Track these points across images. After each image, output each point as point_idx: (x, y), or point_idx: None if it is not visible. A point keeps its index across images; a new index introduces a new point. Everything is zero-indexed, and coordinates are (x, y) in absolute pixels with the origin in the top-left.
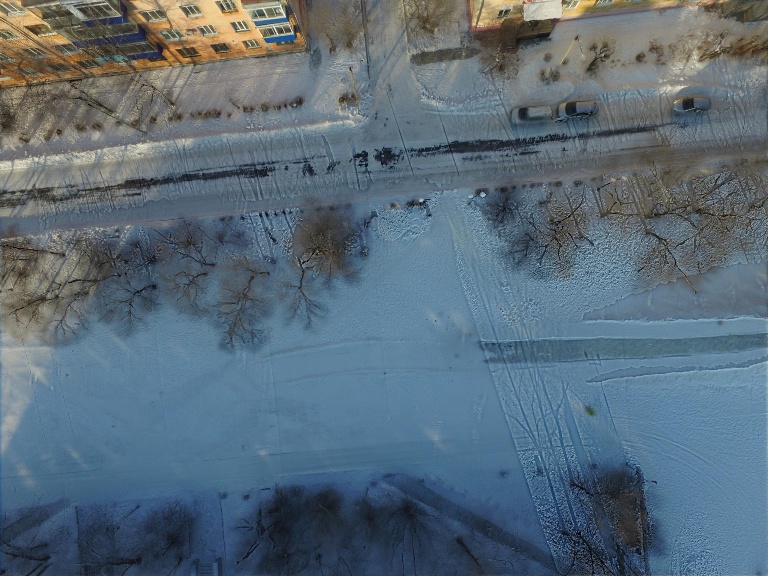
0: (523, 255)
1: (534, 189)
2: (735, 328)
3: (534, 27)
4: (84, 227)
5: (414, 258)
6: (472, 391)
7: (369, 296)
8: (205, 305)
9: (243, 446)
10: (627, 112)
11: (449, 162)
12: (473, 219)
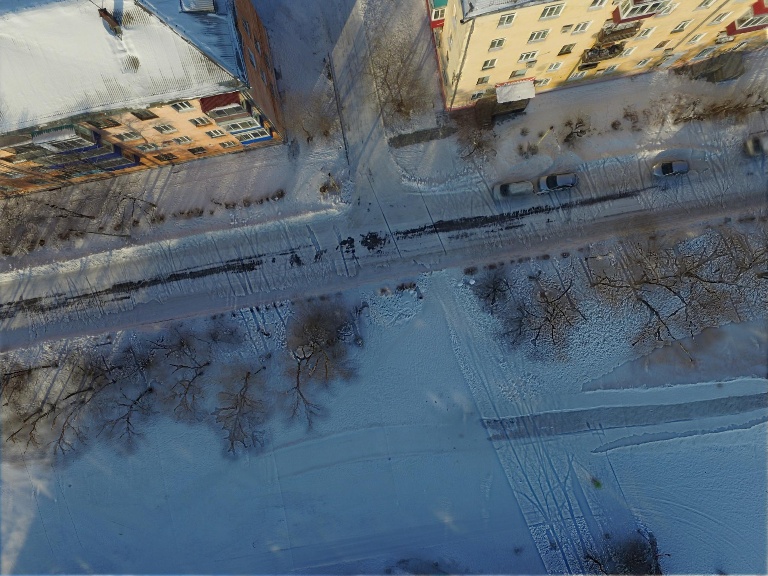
0: (517, 334)
1: (522, 264)
2: (734, 390)
3: (508, 105)
4: (75, 336)
5: (409, 341)
6: (478, 470)
7: (367, 382)
8: (203, 404)
9: (253, 543)
10: (608, 179)
11: (435, 242)
12: (464, 298)
